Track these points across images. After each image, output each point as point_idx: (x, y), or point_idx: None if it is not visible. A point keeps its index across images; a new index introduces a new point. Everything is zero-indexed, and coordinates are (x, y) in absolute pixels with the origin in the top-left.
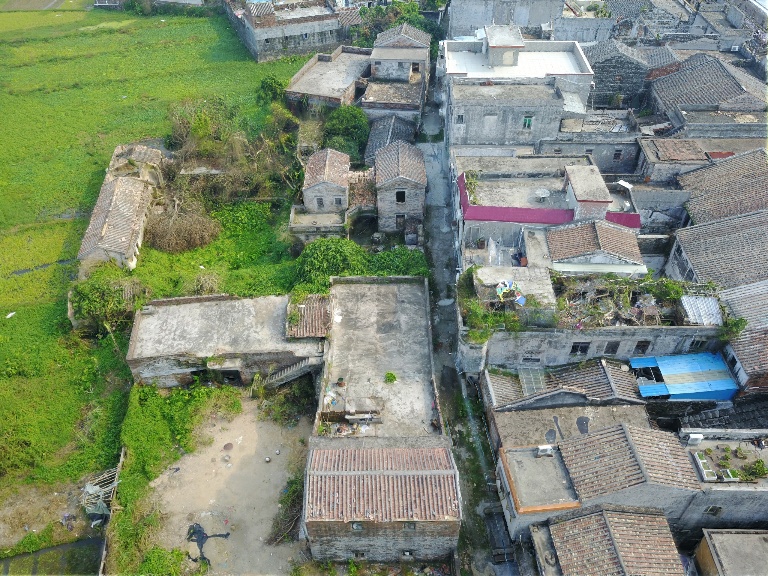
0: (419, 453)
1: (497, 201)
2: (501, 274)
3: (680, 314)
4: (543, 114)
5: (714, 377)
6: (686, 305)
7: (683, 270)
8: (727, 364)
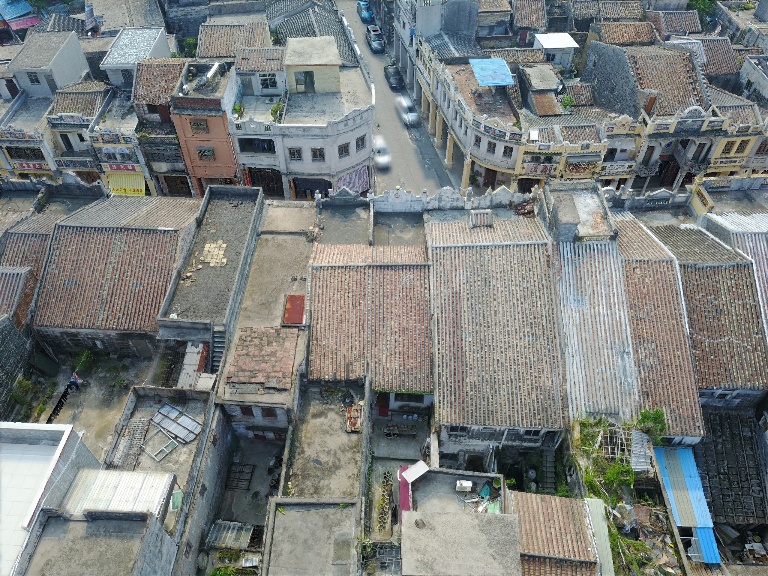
0: None
1: None
2: None
3: (645, 479)
4: (150, 567)
5: (677, 467)
6: (639, 468)
7: (490, 436)
8: (658, 446)
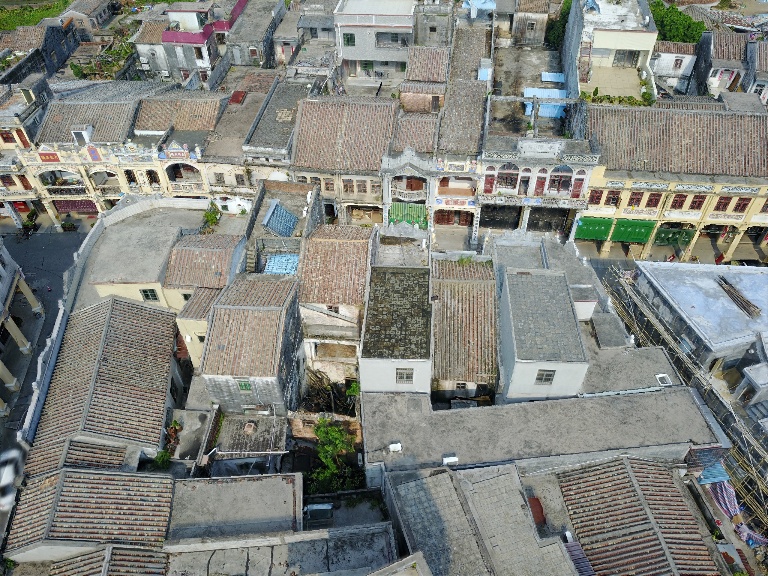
0: (90, 8)
1: (217, 4)
2: (159, 8)
3: None
4: None
5: None
6: None
7: None
8: None
